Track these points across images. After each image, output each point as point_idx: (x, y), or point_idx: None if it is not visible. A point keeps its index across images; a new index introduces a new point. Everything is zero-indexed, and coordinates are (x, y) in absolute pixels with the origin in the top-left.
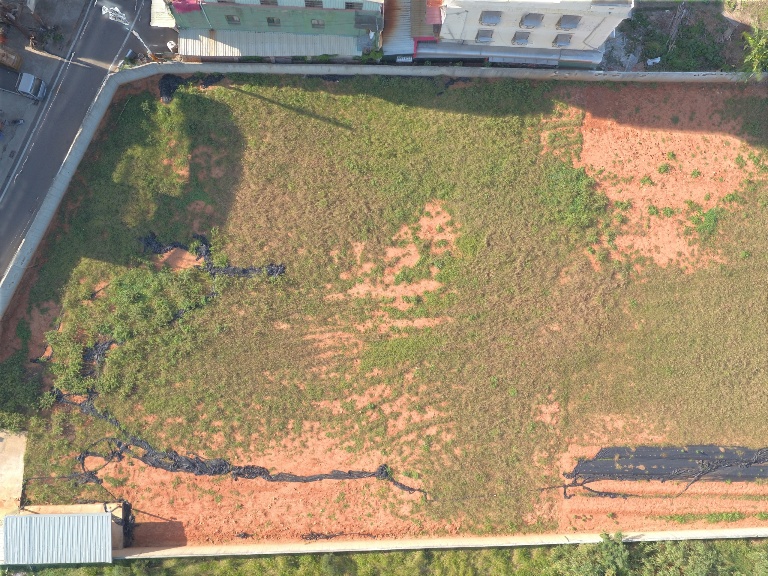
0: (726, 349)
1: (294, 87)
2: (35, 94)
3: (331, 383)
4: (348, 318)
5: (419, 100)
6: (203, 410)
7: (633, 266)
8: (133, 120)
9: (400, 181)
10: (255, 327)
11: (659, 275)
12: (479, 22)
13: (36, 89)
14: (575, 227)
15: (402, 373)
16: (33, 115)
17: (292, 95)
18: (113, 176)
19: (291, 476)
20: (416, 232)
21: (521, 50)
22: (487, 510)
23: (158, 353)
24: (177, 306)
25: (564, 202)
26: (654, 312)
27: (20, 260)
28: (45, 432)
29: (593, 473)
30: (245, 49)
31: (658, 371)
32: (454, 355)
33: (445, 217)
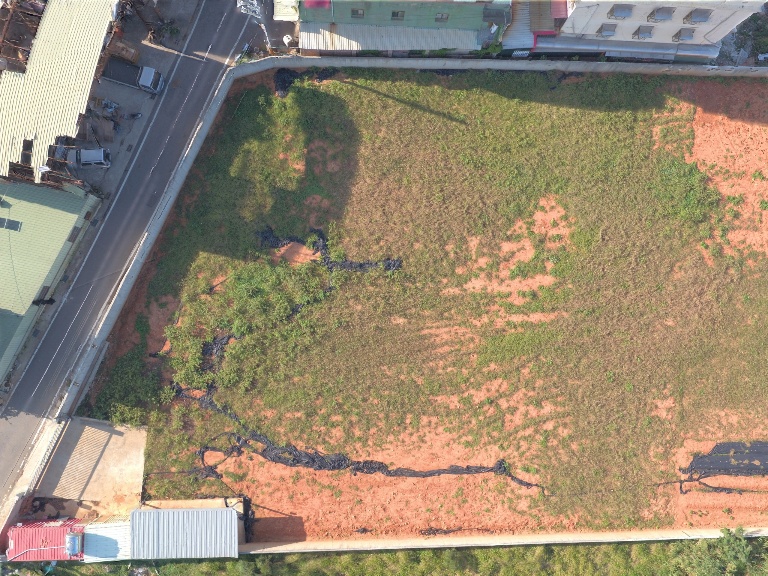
0: None
1: (408, 81)
2: (155, 88)
3: (448, 378)
4: (464, 313)
5: (533, 95)
6: (321, 405)
7: (746, 261)
8: (249, 114)
9: (515, 176)
10: (372, 322)
11: None
12: (607, 16)
13: (155, 83)
14: (688, 222)
15: (518, 368)
16: (150, 109)
17: (407, 89)
18: (230, 170)
19: (410, 471)
20: (531, 227)
21: (638, 44)
22: (605, 505)
23: (277, 347)
24: (295, 300)
25: (677, 197)
26: (767, 307)
27: (141, 254)
28: (165, 427)
29: (708, 468)
30: (365, 43)
31: None
32: (570, 350)
33: (559, 212)
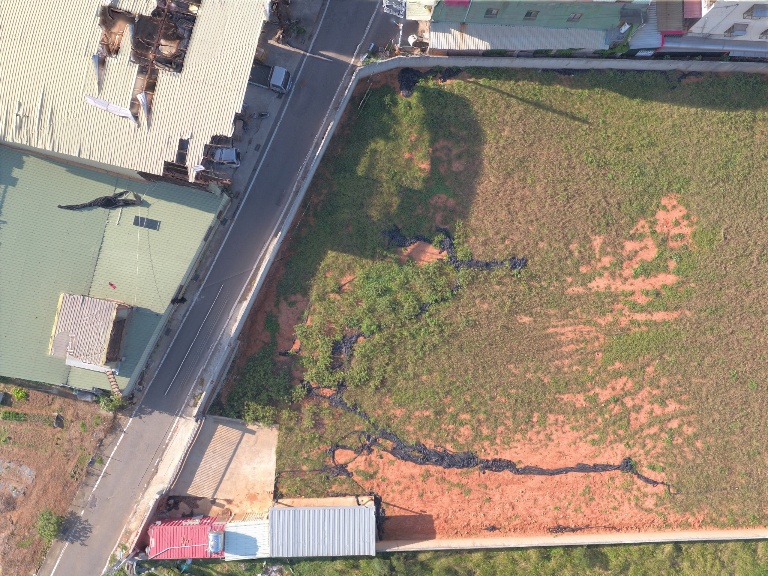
0: None
1: (531, 81)
2: (285, 87)
3: (574, 376)
4: (588, 311)
5: (654, 94)
6: (450, 403)
7: None
8: (375, 114)
9: (637, 175)
10: (499, 320)
11: None
12: (743, 16)
13: (285, 82)
14: None
15: (643, 366)
16: (277, 108)
17: (530, 89)
18: (358, 169)
19: (537, 469)
20: (653, 226)
21: (763, 44)
22: (730, 503)
23: (405, 346)
24: (422, 299)
25: None
26: None
27: (273, 253)
28: (296, 425)
29: None
30: (495, 43)
31: None
32: (694, 348)
33: (681, 211)
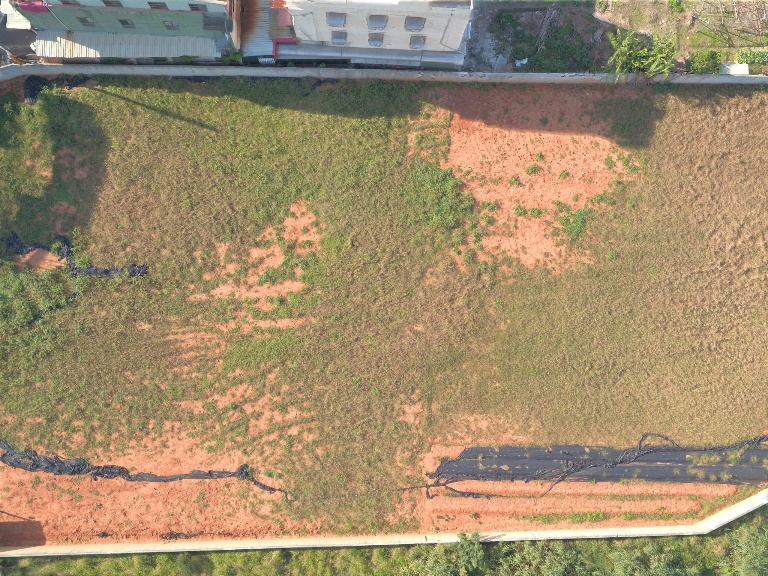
0: (592, 349)
1: (159, 88)
2: None
3: (192, 383)
4: (211, 318)
5: (285, 101)
6: (63, 410)
7: (500, 267)
8: None
9: (265, 182)
10: (116, 327)
11: (525, 276)
12: (327, 24)
13: None
14: (440, 228)
15: (264, 373)
16: None
17: (157, 96)
18: None
19: (151, 476)
20: (280, 233)
21: (382, 51)
22: (348, 510)
23: (18, 353)
24: (38, 306)
25: (430, 203)
26: (520, 313)
27: None
28: None
29: (456, 473)
30: (103, 51)
31: (523, 371)
32: (317, 355)
33: (310, 218)
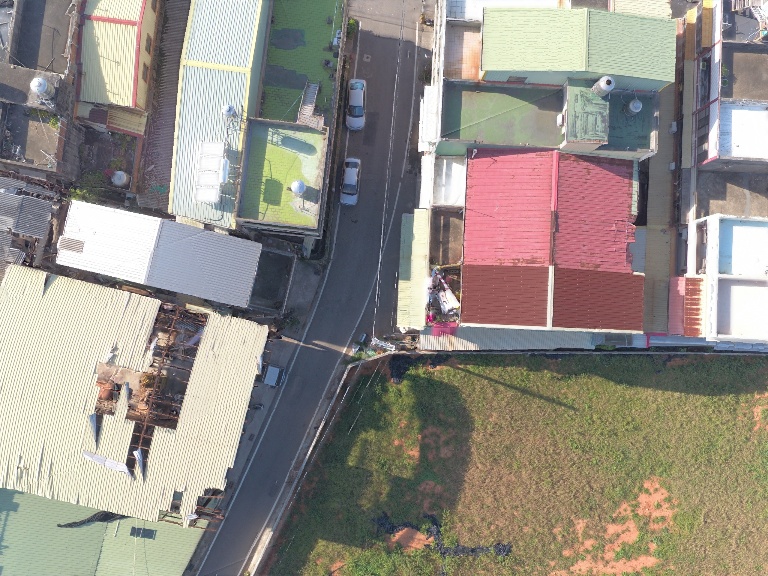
0: None
1: (519, 367)
2: (278, 384)
3: None
4: None
5: (639, 379)
6: None
7: None
8: (366, 402)
9: (621, 460)
10: None
11: None
12: None
13: (279, 379)
14: None
15: None
16: (271, 398)
17: (518, 375)
18: (348, 459)
19: None
20: (635, 509)
21: None
22: None
23: None
24: None
25: None
26: None
27: None
28: None
29: None
30: (483, 344)
31: None
32: None
33: (663, 494)
